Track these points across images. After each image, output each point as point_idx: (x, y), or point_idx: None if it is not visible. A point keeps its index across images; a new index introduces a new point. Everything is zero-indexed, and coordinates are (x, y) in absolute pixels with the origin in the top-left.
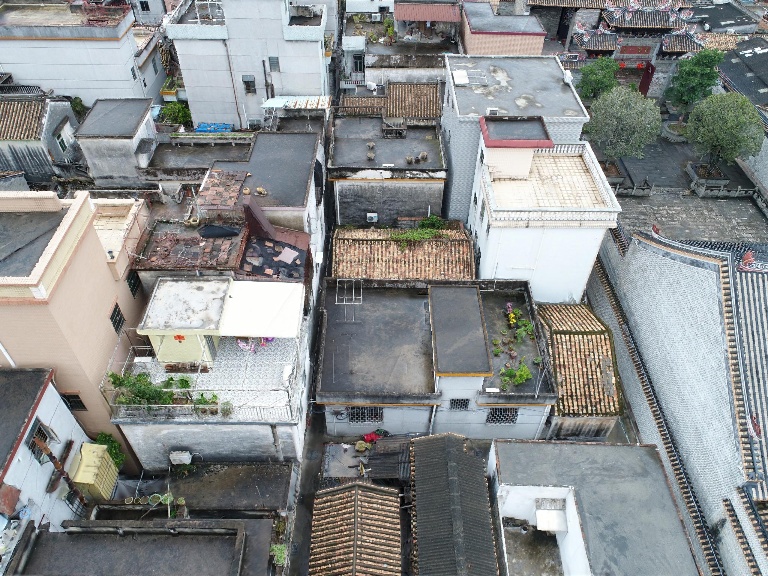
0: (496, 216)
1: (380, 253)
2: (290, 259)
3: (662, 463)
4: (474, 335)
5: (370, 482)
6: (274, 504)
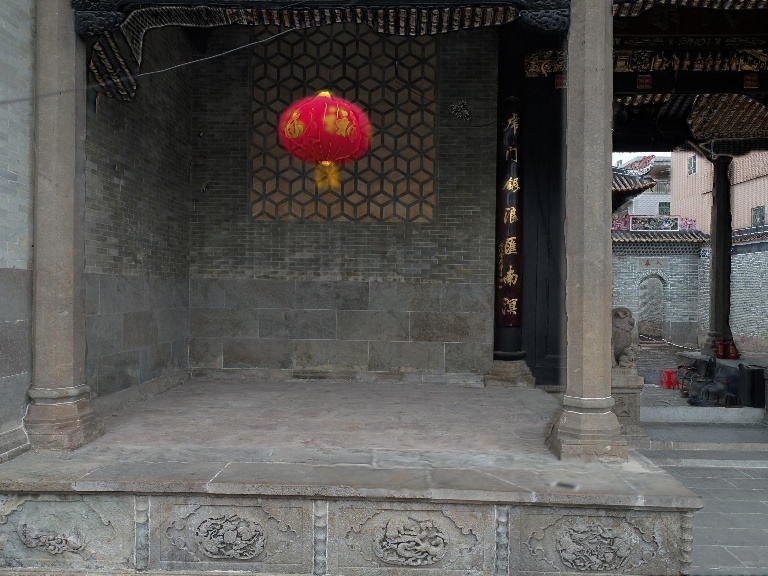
0: None
1: None
2: None
3: None
4: None
5: None
6: None
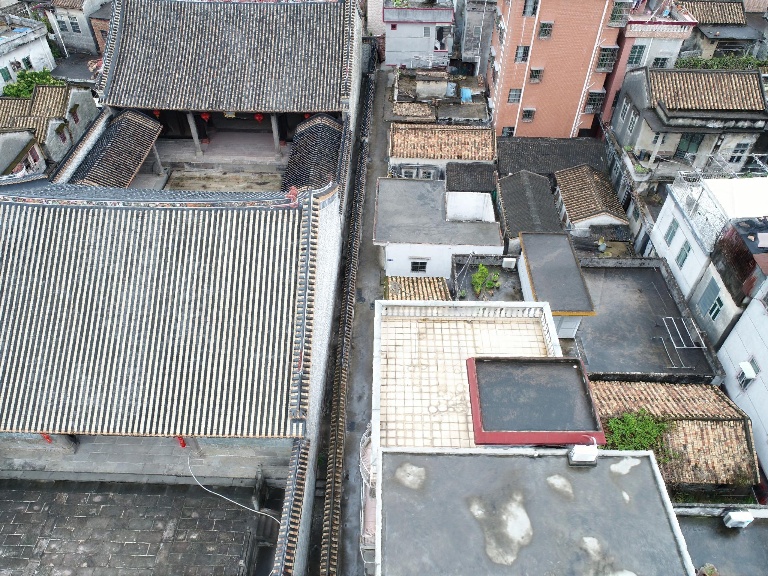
0: (540, 313)
1: (671, 407)
2: (762, 238)
3: (375, 232)
4: (538, 262)
5: (592, 235)
6: (656, 208)
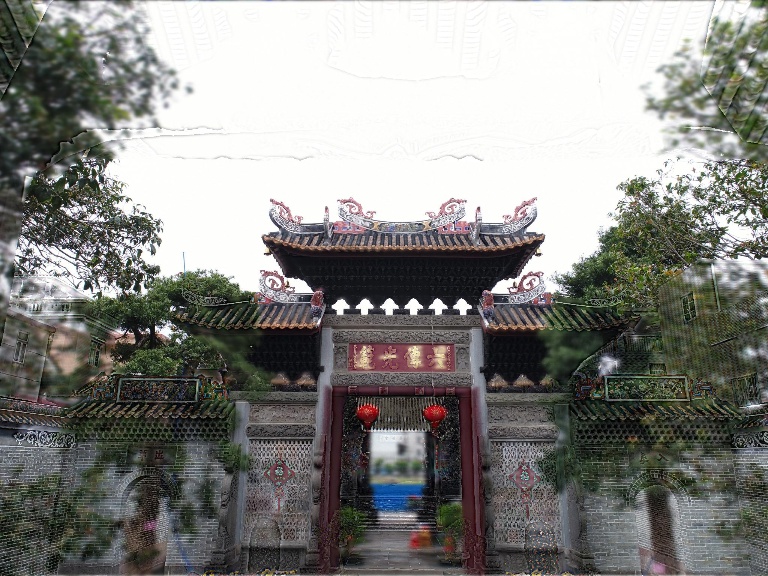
0: None
1: None
2: None
3: None
4: None
5: None
6: None
